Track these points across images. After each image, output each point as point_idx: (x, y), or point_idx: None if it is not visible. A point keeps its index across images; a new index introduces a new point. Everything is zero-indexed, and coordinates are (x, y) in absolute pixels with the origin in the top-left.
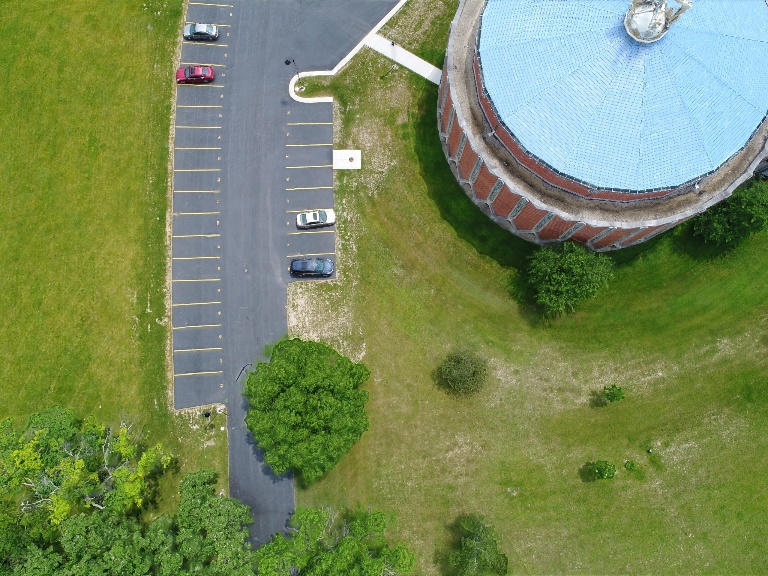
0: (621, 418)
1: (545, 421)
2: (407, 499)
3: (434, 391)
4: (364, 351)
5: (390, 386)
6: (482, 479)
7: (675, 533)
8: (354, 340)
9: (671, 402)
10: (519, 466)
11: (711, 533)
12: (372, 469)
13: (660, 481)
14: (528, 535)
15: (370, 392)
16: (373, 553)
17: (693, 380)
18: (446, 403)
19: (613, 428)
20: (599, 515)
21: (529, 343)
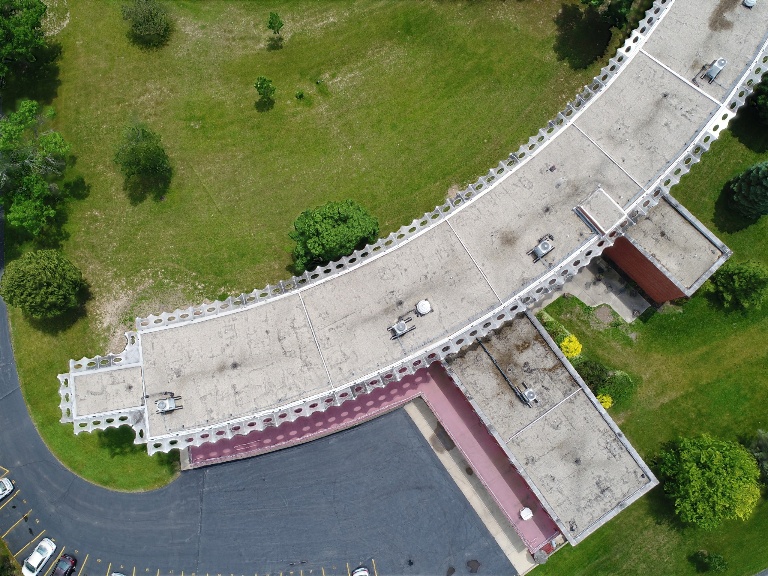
0: (295, 58)
1: (227, 65)
2: (102, 139)
3: (129, 48)
4: (68, 19)
5: (90, 47)
6: (169, 117)
7: (337, 146)
8: (59, 11)
9: (340, 41)
10: (202, 104)
11: (368, 144)
12: (72, 117)
13: (326, 106)
14: (208, 160)
15: (72, 53)
16: (35, 145)
17: (360, 22)
18: (139, 57)
19: (287, 66)
20: (271, 138)
21: (217, 4)
